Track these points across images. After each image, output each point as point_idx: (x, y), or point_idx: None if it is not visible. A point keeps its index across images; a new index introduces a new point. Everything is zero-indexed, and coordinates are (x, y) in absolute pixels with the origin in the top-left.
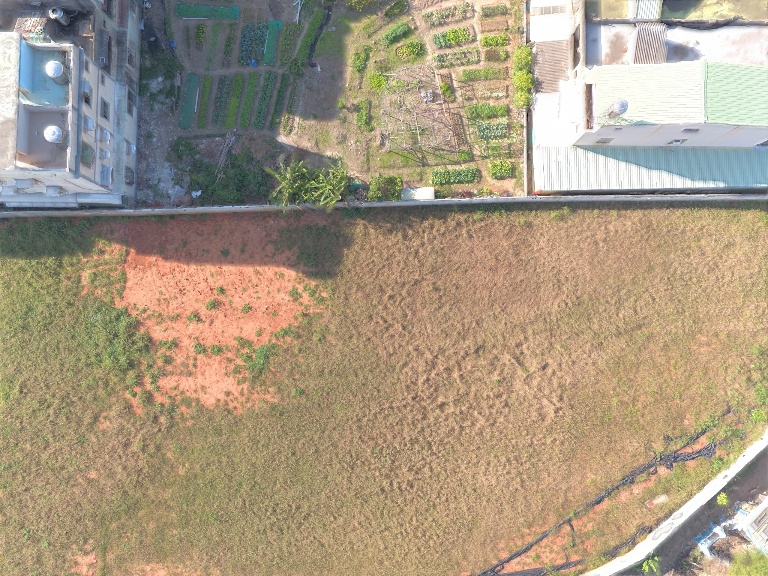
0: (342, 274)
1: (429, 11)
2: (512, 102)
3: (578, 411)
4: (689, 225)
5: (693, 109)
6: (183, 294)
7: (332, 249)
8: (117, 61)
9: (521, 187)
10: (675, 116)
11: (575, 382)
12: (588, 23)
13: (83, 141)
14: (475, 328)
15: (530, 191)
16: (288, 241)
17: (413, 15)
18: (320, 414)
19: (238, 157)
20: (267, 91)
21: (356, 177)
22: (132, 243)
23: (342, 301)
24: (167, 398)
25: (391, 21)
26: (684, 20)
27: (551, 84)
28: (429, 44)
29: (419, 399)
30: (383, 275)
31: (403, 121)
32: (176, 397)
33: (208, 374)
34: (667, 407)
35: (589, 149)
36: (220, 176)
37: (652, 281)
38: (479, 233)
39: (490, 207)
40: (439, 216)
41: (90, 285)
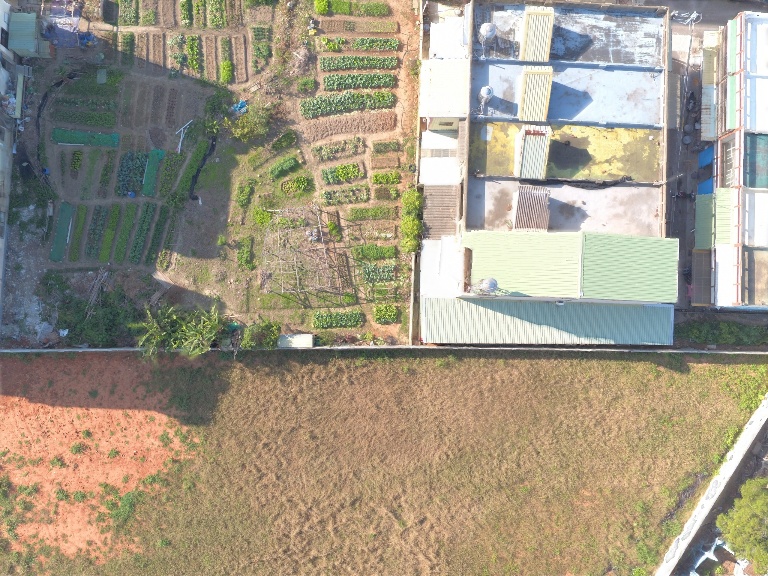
0: (215, 420)
1: (318, 145)
2: None
3: (455, 568)
4: (577, 377)
5: (569, 283)
6: (47, 436)
7: (206, 393)
8: None
9: (406, 333)
10: (550, 290)
11: (453, 538)
12: (472, 178)
13: None
14: (352, 479)
15: (416, 336)
16: (160, 383)
17: (301, 148)
18: (187, 566)
19: (110, 294)
20: (144, 224)
21: (234, 318)
22: None
23: (214, 448)
24: (25, 546)
25: (278, 154)
26: (570, 179)
27: (438, 231)
28: (317, 179)
29: (291, 553)
30: (259, 421)
31: (286, 260)
32: (35, 545)
33: (70, 522)
34: (547, 565)
35: (473, 302)
36: (90, 313)
37: (537, 434)
38: (361, 380)
39: (373, 353)
40: (319, 361)
41: None
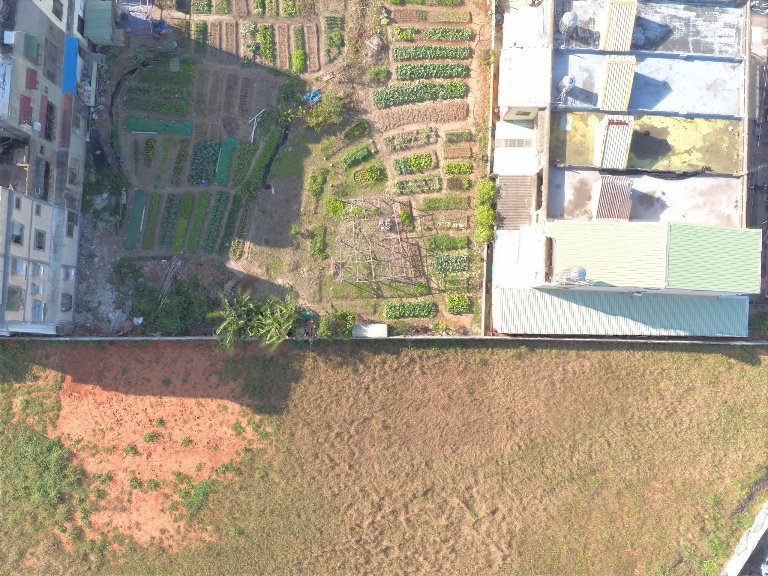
0: (288, 409)
1: (390, 134)
2: (473, 234)
3: (527, 559)
4: (649, 368)
5: (654, 273)
6: (120, 424)
7: (279, 382)
8: (56, 183)
9: (478, 323)
10: (635, 280)
11: (525, 528)
12: (552, 168)
13: (10, 286)
14: (424, 469)
15: (488, 326)
16: (233, 372)
17: (374, 138)
18: (259, 555)
19: (183, 283)
20: (217, 213)
21: (307, 307)
22: (68, 369)
23: (287, 437)
24: (99, 534)
25: (350, 143)
26: (650, 170)
27: (513, 221)
28: (389, 169)
29: (363, 542)
30: (331, 411)
31: (358, 250)
32: (109, 533)
33: (143, 510)
34: (618, 556)
35: (549, 292)
36: (164, 302)
37: (608, 426)
38: (433, 370)
39: (445, 343)
40: (392, 351)
41: (21, 412)
